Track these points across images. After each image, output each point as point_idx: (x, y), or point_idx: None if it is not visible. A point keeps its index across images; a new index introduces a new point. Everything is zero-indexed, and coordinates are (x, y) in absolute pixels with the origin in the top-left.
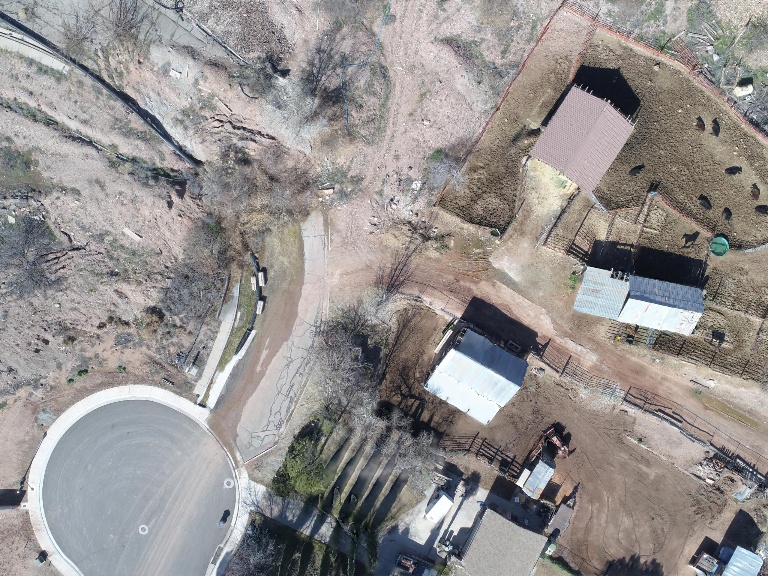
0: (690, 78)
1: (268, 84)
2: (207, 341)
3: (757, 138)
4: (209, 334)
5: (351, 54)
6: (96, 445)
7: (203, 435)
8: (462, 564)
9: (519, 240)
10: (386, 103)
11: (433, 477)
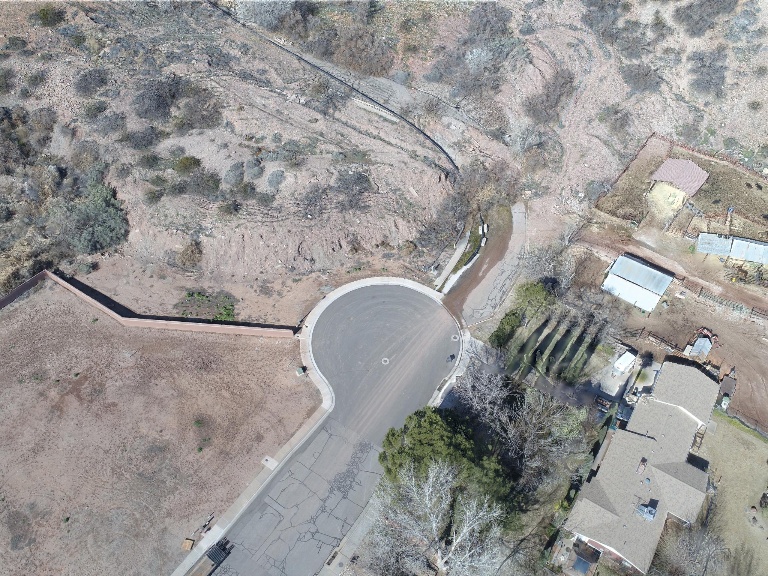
0: (735, 168)
1: (501, 135)
2: (445, 259)
3: None
4: (447, 256)
5: (544, 133)
6: (359, 306)
7: (438, 307)
8: (652, 395)
9: (650, 228)
10: (562, 157)
11: (615, 347)
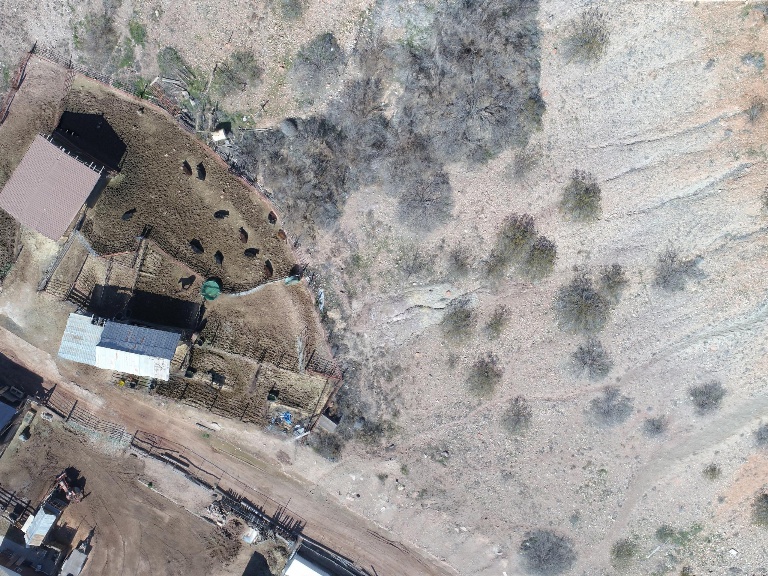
0: (174, 123)
1: None
2: None
3: (243, 182)
4: None
5: None
6: None
7: None
8: None
9: (21, 285)
10: None
11: None
